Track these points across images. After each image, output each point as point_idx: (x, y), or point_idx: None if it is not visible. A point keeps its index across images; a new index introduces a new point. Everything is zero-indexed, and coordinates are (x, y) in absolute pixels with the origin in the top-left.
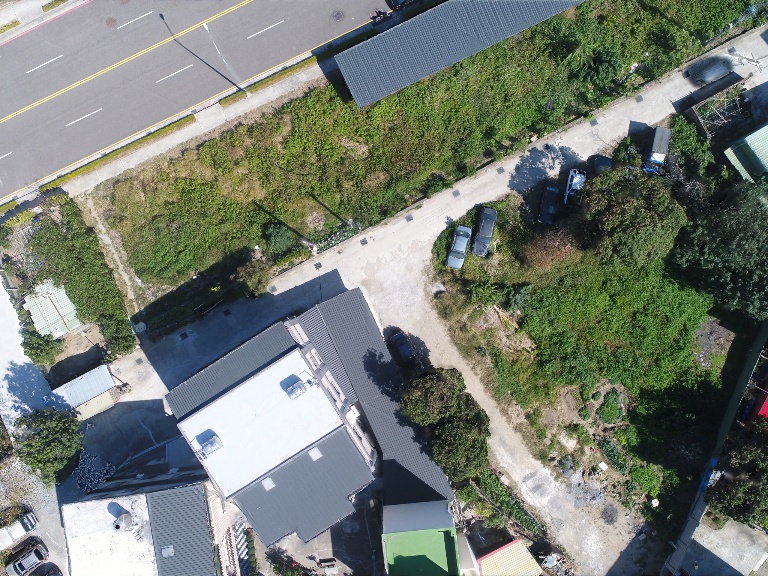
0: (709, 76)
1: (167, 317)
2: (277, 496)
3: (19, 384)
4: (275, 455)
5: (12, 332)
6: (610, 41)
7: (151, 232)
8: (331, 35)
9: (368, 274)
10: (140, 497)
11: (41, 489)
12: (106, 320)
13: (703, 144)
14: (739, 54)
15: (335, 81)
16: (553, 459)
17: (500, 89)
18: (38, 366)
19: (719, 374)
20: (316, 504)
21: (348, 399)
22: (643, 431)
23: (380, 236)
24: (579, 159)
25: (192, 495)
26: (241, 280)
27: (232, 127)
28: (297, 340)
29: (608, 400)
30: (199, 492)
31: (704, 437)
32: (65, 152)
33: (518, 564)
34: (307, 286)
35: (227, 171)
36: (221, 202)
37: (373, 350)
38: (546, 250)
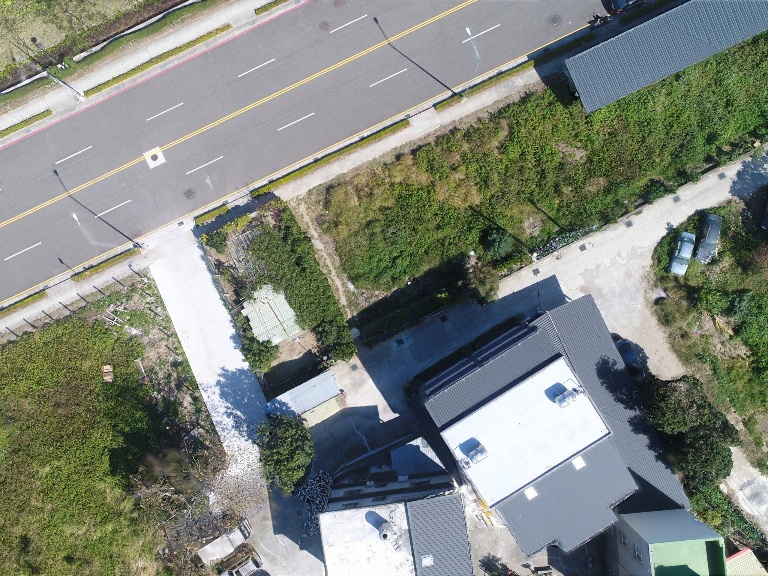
0: None
1: (383, 323)
2: (539, 505)
3: (231, 390)
4: (539, 464)
5: (223, 338)
6: None
7: (365, 237)
8: (547, 39)
9: (587, 280)
10: (398, 506)
11: (254, 496)
12: (329, 326)
13: None
14: None
15: (554, 86)
16: None
17: (722, 94)
18: (256, 372)
19: None
20: (578, 513)
21: None
22: None
23: (599, 242)
24: None
25: (451, 504)
26: (473, 286)
27: (447, 132)
28: None
29: None
30: (458, 501)
31: None
32: (277, 156)
33: (748, 573)
34: (525, 292)
35: (444, 176)
36: (438, 207)
37: (606, 357)
38: None
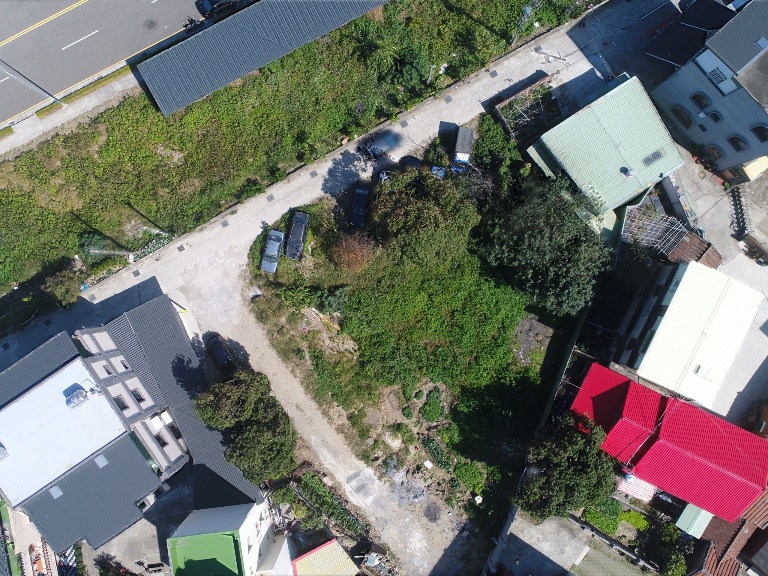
0: (517, 75)
1: None
2: (65, 504)
3: None
4: (61, 463)
5: None
6: (417, 43)
7: None
8: (145, 44)
9: (186, 280)
10: None
11: None
12: None
13: (509, 143)
14: (545, 52)
15: (148, 90)
16: (377, 459)
17: (311, 93)
18: None
19: (539, 370)
20: (104, 511)
21: (157, 405)
22: (464, 429)
23: (197, 242)
24: (391, 161)
25: None
26: (48, 290)
27: (49, 138)
28: (88, 349)
29: (430, 399)
30: None
31: (524, 433)
32: None
33: (334, 564)
34: (126, 294)
35: (43, 182)
36: (39, 213)
37: (181, 356)
38: (361, 252)
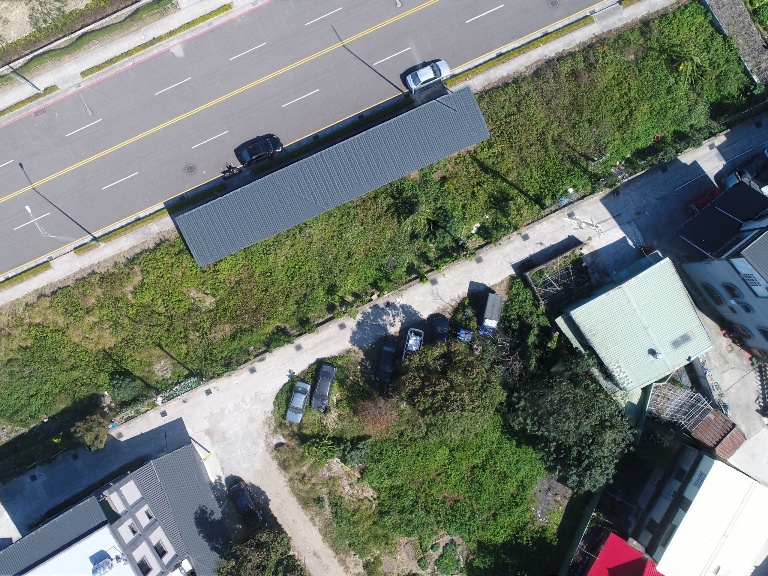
0: (548, 239)
1: (17, 459)
2: None
3: None
4: None
5: None
6: (451, 203)
7: (5, 375)
8: (183, 188)
9: (212, 423)
10: None
11: None
12: None
13: (537, 309)
14: (578, 218)
15: None
16: None
17: (343, 247)
18: None
19: (556, 530)
20: None
21: (178, 555)
22: None
23: (224, 387)
24: (419, 317)
25: None
26: (78, 435)
27: (86, 275)
28: (115, 509)
29: (446, 552)
30: None
31: None
32: None
33: None
34: (152, 433)
35: (78, 319)
36: (72, 349)
37: (204, 507)
38: None
